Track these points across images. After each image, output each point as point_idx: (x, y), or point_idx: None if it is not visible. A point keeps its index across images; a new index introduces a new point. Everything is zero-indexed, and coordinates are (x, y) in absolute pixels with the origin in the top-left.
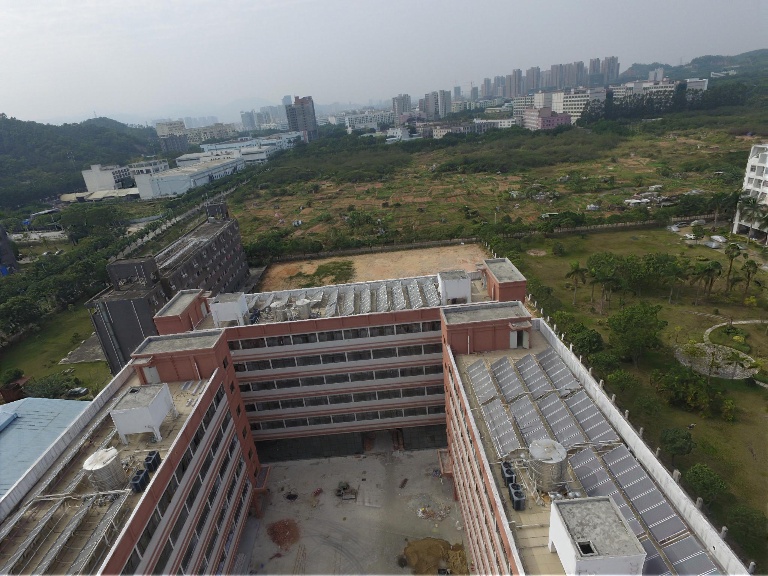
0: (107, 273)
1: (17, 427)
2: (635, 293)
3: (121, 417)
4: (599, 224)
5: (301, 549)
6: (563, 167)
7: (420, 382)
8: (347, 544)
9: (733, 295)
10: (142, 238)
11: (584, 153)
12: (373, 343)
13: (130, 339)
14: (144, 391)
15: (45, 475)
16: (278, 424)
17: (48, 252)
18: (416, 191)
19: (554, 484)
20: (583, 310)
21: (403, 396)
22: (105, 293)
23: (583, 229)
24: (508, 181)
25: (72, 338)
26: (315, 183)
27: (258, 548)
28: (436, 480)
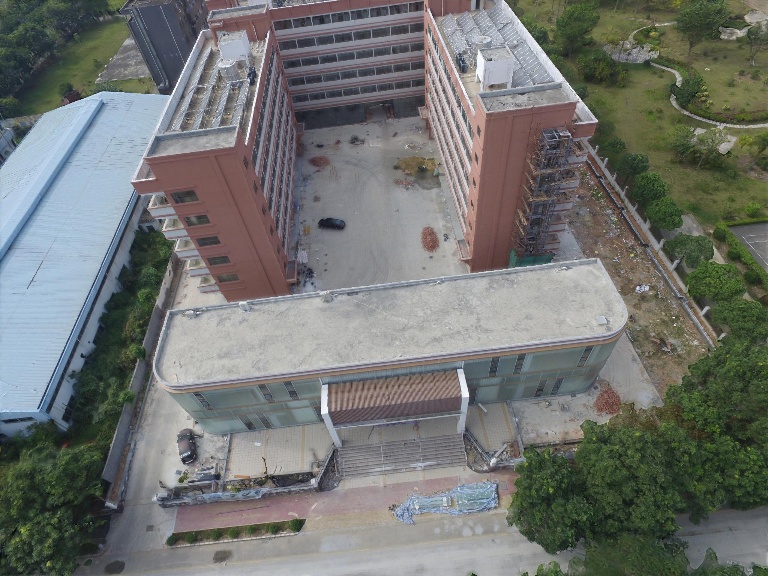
0: (93, 4)
1: (108, 108)
2: None
3: (225, 48)
4: None
5: (332, 167)
6: None
7: (407, 58)
8: (361, 163)
9: (668, 3)
10: None
11: None
12: (373, 23)
13: (164, 46)
14: (232, 34)
15: (187, 85)
16: (304, 98)
17: None
18: None
19: None
20: (542, 21)
21: (394, 71)
22: (130, 3)
23: None
24: None
25: (95, 63)
26: None
27: (305, 169)
28: (417, 132)
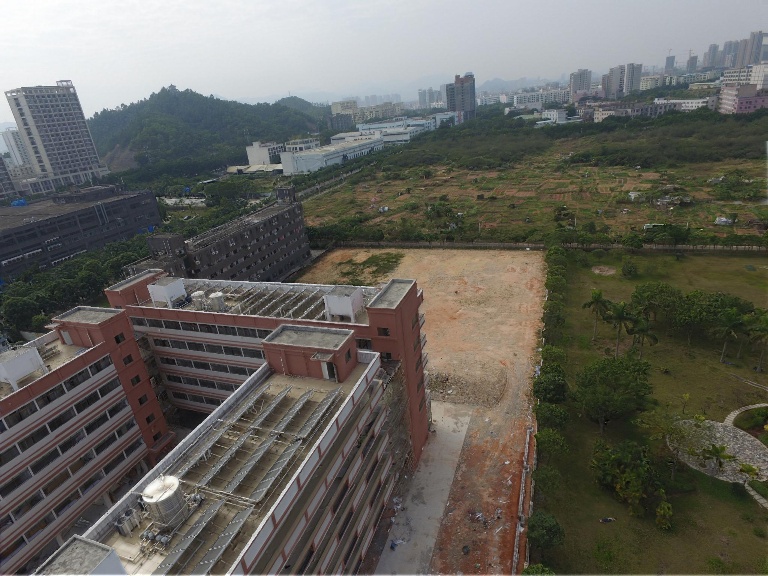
0: None
1: None
2: (655, 341)
3: None
4: (711, 244)
5: None
6: (731, 164)
7: None
8: None
9: None
10: None
11: None
12: None
13: None
14: (19, 350)
15: None
16: (200, 399)
17: (188, 216)
18: (526, 184)
19: None
20: (598, 349)
21: None
22: (144, 260)
23: (687, 248)
24: (641, 179)
25: None
26: (435, 168)
27: None
28: None
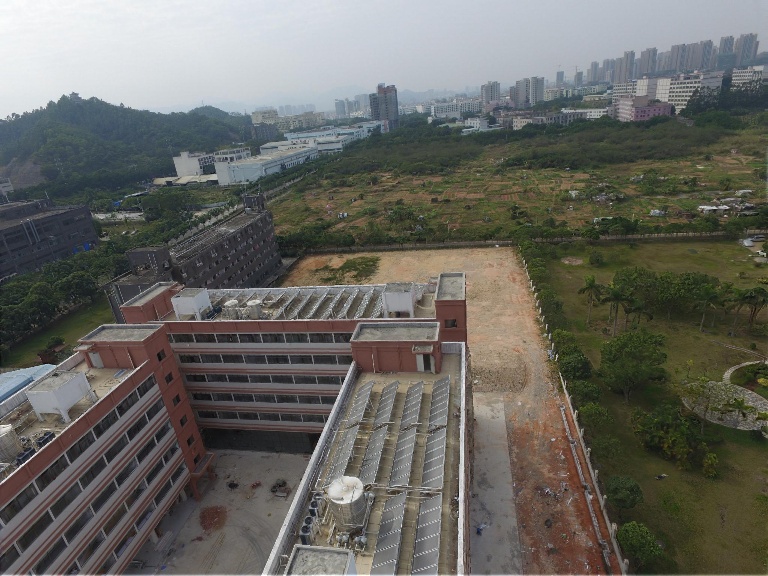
0: None
1: None
2: (651, 317)
3: (34, 398)
4: (655, 233)
5: (221, 537)
6: (644, 164)
7: None
8: (262, 540)
9: None
10: (204, 223)
11: (673, 149)
12: (313, 349)
13: None
14: (63, 376)
15: None
16: (233, 415)
17: (126, 231)
18: (472, 186)
19: (346, 525)
20: (595, 330)
21: None
22: (124, 277)
23: (635, 237)
24: (574, 179)
25: None
26: (377, 174)
27: (186, 528)
28: None
